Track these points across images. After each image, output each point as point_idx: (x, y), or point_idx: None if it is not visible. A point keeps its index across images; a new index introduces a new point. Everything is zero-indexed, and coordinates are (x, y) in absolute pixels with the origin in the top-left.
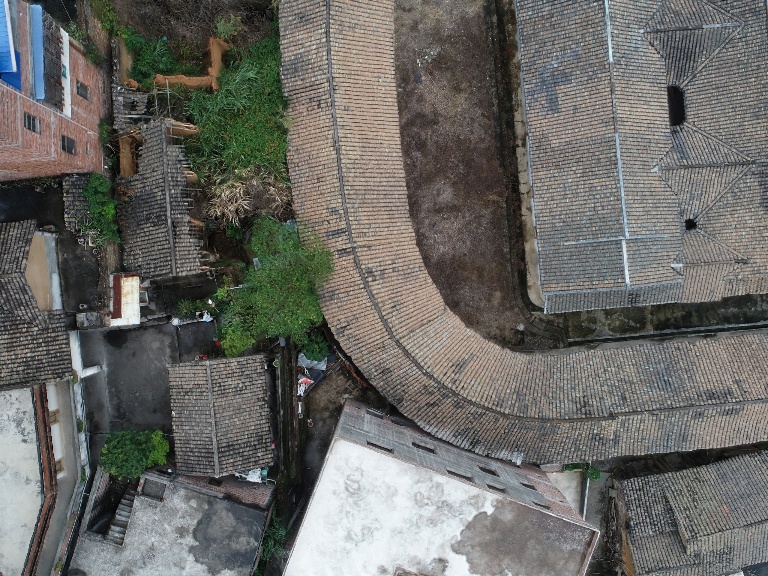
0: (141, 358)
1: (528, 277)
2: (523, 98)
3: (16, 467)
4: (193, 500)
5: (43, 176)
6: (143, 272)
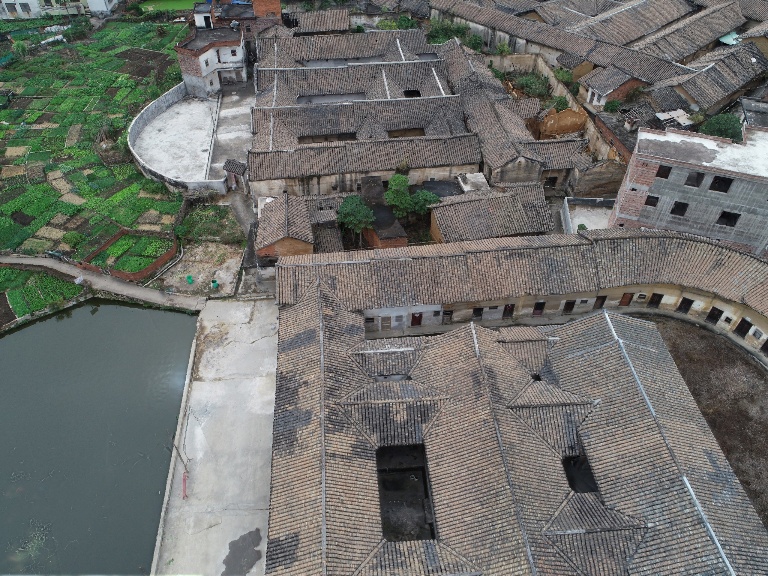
0: None
1: None
2: None
3: None
4: None
5: None
6: None
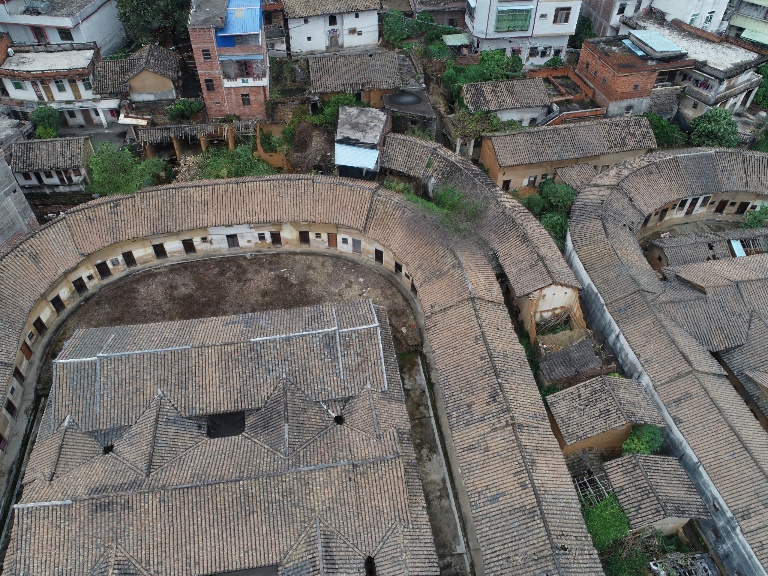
0: None
1: None
2: None
3: None
4: (5, 137)
5: None
6: None
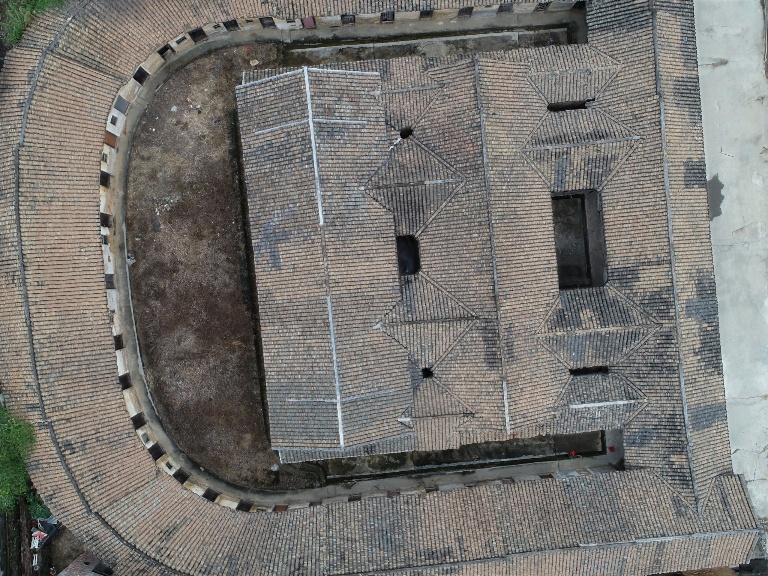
0: None
1: None
2: None
3: None
4: None
5: None
6: None
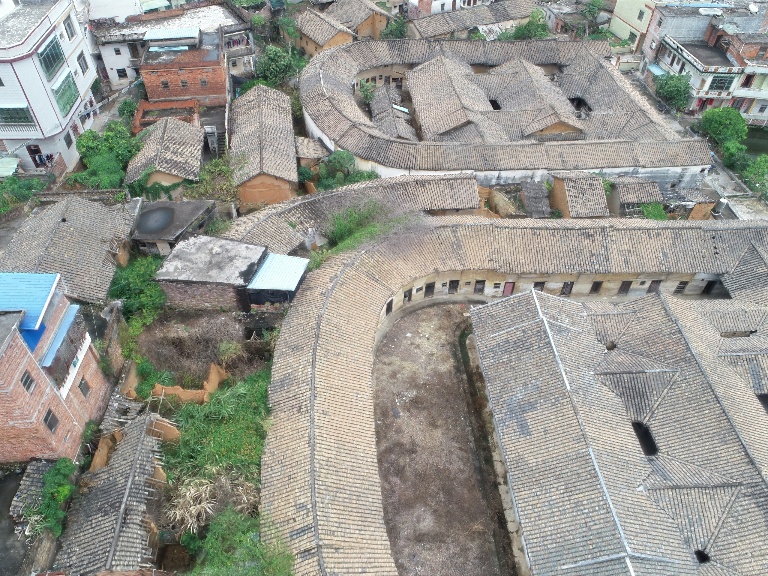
0: None
1: None
2: None
3: None
4: None
5: (11, 461)
6: (72, 572)
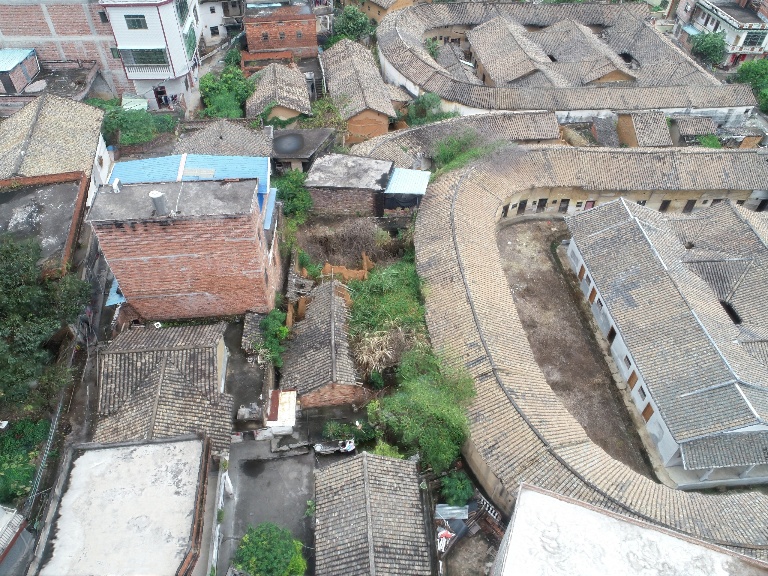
0: (276, 488)
1: (651, 460)
2: (599, 322)
3: (160, 522)
4: None
5: (229, 314)
6: (299, 390)
